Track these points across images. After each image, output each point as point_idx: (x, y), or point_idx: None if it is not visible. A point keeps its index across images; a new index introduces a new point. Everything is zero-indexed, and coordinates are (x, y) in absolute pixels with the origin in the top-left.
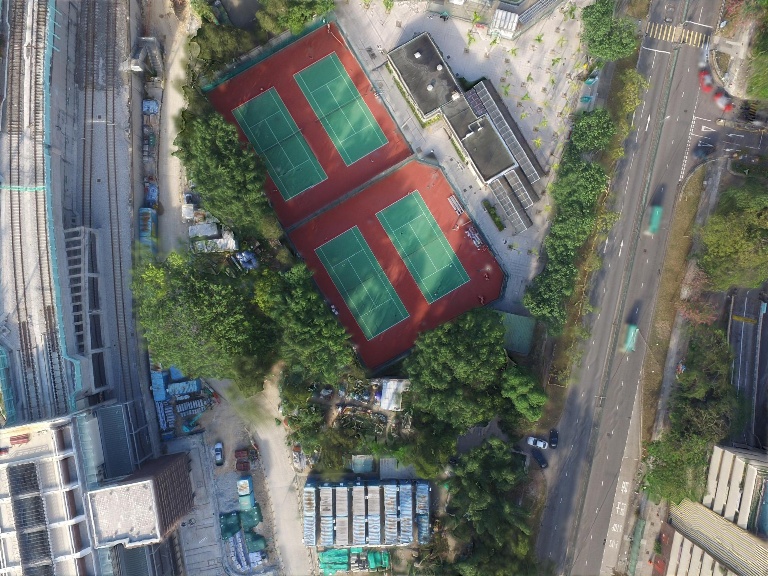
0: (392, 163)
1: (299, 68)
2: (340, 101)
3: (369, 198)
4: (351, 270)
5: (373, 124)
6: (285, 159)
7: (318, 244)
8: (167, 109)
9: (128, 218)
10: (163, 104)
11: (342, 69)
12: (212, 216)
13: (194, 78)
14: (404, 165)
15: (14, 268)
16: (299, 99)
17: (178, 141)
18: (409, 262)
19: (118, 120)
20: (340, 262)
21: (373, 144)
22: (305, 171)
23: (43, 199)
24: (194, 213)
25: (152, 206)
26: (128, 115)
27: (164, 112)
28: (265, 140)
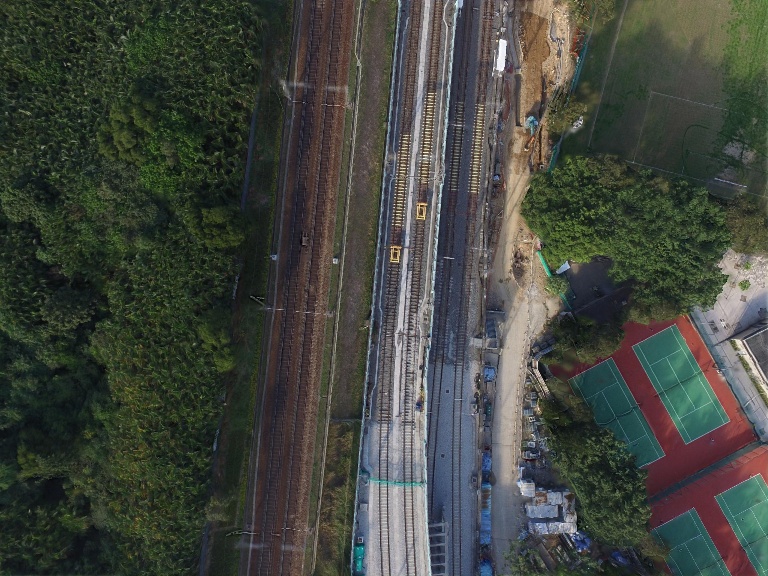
0: (734, 444)
1: (639, 340)
2: (680, 375)
3: (709, 480)
4: (689, 556)
5: (714, 401)
6: (621, 433)
7: (654, 525)
8: (502, 375)
9: (470, 495)
10: (499, 370)
11: (683, 342)
12: (553, 497)
13: (531, 345)
14: (747, 447)
15: (381, 565)
16: (637, 371)
17: (554, 444)
18: (750, 551)
19: (465, 395)
20: (676, 546)
21: (714, 422)
22: (643, 448)
23: (411, 493)
24: (535, 493)
25: (489, 479)
26: (475, 390)
27: (500, 379)
28: (601, 412)
